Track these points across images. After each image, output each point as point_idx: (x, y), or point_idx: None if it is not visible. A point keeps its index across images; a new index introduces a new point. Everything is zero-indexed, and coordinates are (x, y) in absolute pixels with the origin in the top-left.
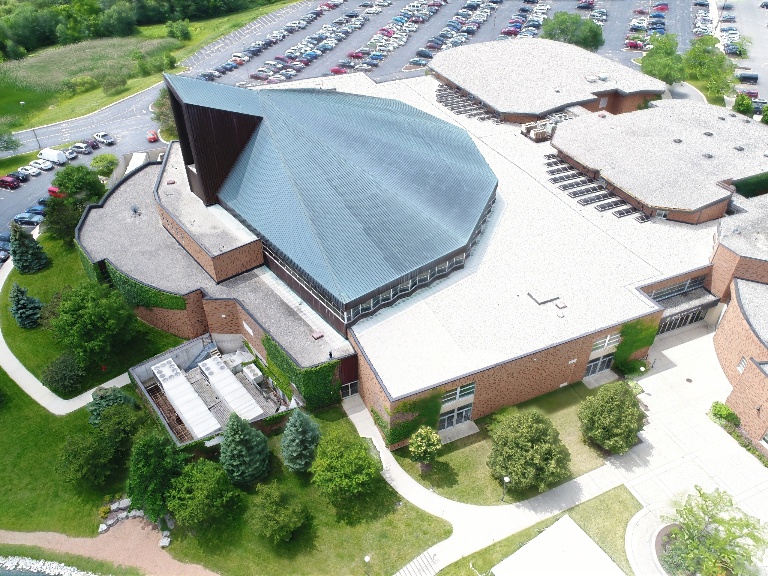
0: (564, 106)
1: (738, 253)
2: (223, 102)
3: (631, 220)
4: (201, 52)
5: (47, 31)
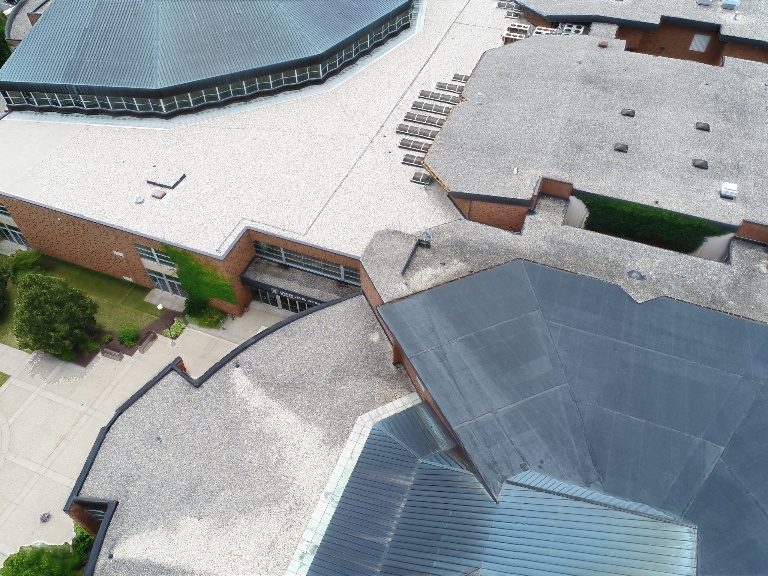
0: (591, 18)
1: (362, 255)
2: None
3: (409, 173)
4: None
5: None
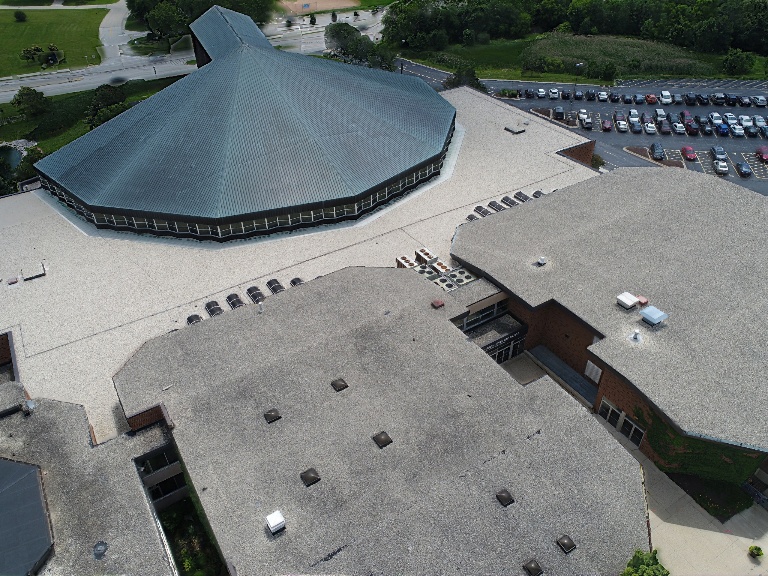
0: (482, 273)
1: None
2: (209, 38)
3: None
4: (667, 81)
5: (640, 23)
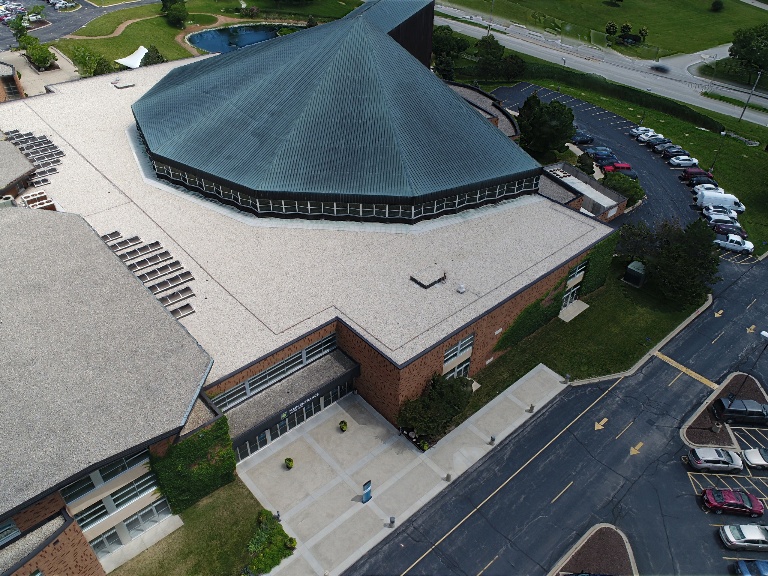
0: None
1: None
2: (369, 1)
3: (7, 131)
4: None
5: None
